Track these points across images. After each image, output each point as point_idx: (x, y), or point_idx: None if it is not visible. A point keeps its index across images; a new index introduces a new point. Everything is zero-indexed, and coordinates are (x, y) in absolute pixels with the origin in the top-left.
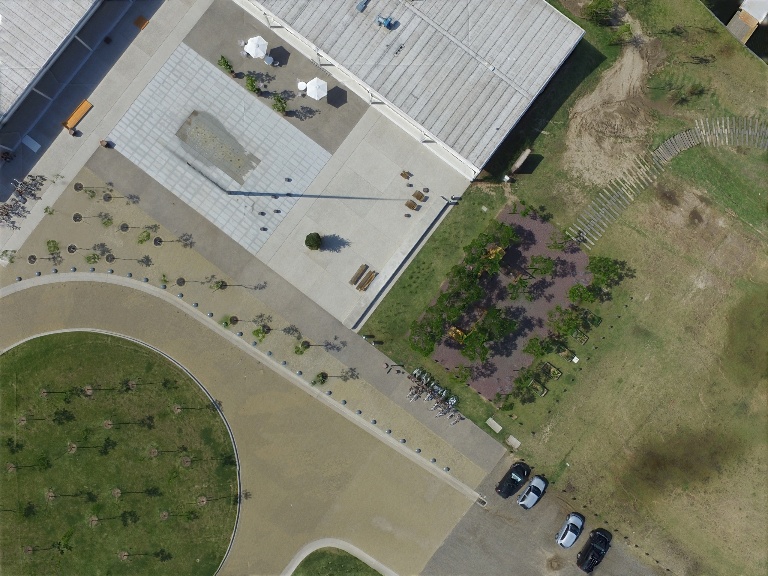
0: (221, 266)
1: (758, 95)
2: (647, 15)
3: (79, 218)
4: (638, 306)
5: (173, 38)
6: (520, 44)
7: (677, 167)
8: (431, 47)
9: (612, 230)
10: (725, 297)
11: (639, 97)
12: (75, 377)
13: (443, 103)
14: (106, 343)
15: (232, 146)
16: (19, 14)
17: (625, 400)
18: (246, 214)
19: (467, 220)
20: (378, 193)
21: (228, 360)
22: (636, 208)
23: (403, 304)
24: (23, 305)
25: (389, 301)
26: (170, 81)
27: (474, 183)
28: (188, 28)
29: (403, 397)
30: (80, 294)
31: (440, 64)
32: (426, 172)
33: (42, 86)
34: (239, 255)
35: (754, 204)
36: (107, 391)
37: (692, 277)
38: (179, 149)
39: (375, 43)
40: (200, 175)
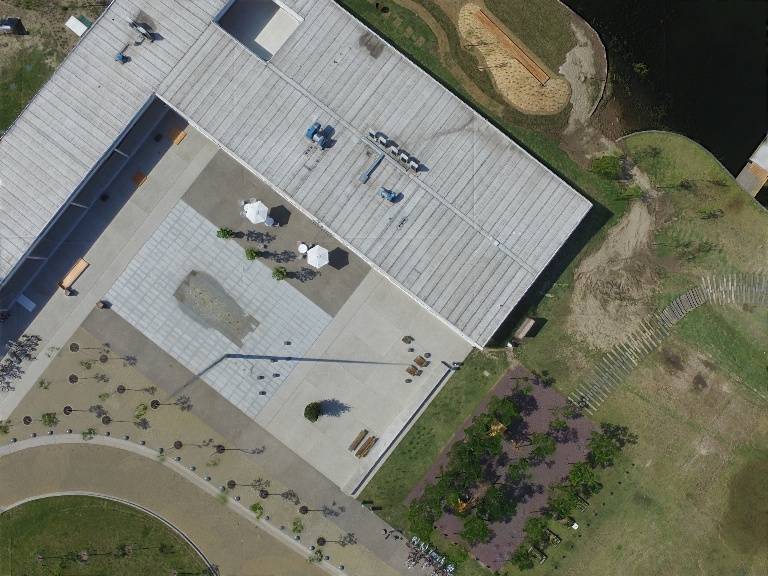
0: (219, 430)
1: (766, 251)
2: (656, 168)
3: (75, 379)
4: (639, 472)
5: (171, 195)
6: (526, 218)
7: (682, 331)
8: (435, 220)
9: (615, 396)
10: (727, 463)
11: (645, 254)
12: (71, 542)
13: (446, 278)
14: (102, 507)
15: (231, 307)
16: (13, 180)
17: (624, 567)
18: (245, 377)
19: (468, 385)
20: (379, 357)
21: (225, 524)
22: (640, 373)
23: (402, 470)
24: (18, 467)
25: (388, 467)
26: (168, 240)
27: (476, 348)
28: (187, 185)
29: (401, 563)
30: (76, 456)
31: (444, 238)
32: (428, 336)
33: (37, 251)
34: (237, 419)
35: (759, 366)
36: (103, 556)
37: (694, 443)
38: (177, 310)
39: (378, 216)
40: (198, 337)
